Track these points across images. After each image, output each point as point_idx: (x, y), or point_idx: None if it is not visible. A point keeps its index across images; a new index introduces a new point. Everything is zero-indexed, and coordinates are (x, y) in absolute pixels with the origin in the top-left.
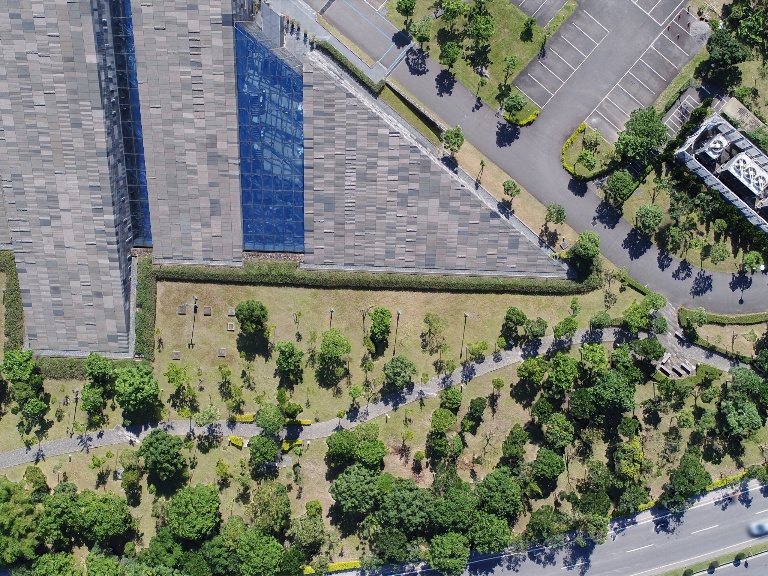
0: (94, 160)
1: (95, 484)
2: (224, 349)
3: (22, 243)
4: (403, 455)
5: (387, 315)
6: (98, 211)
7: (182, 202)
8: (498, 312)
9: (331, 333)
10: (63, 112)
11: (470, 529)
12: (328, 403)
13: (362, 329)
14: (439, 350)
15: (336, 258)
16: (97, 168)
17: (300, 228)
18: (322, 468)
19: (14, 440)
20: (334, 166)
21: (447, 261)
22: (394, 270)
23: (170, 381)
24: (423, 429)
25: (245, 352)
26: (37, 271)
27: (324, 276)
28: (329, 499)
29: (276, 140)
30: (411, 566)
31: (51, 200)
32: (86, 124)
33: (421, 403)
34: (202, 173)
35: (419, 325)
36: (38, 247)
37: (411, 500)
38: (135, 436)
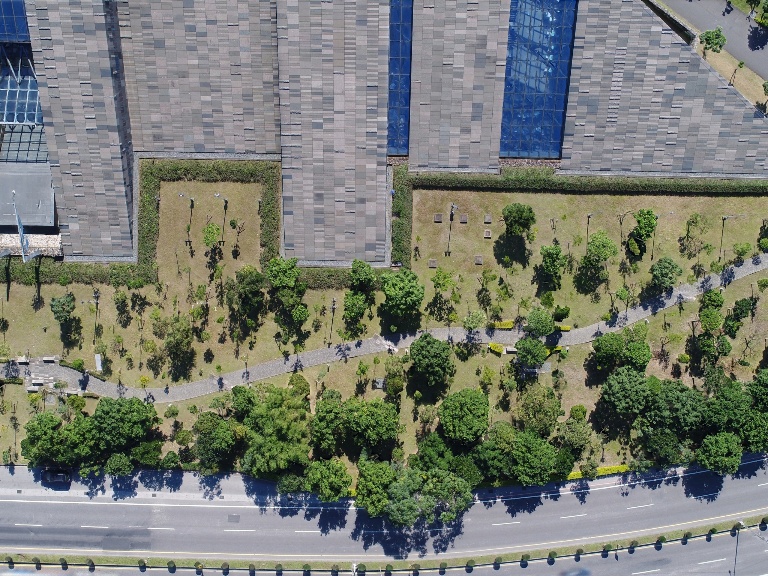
0: (375, 59)
1: (354, 394)
2: (481, 256)
3: (291, 148)
4: (662, 360)
5: (652, 217)
6: (372, 113)
7: (444, 107)
8: (756, 215)
9: (599, 235)
10: (350, 9)
11: (741, 429)
12: (586, 309)
13: (619, 234)
14: (697, 254)
15: (593, 163)
16: (377, 67)
17: (557, 133)
18: (581, 374)
19: (271, 351)
20: (602, 66)
21: (705, 164)
22: (650, 175)
23: (436, 286)
24: (682, 333)
25: (502, 259)
26: (303, 177)
27: (583, 181)
28: (589, 405)
29: (523, 49)
30: (673, 470)
31: (326, 102)
32: (371, 21)
33: (680, 307)
34: (468, 76)
35: (677, 229)
36: (307, 152)
37: (686, 399)
38: (393, 345)
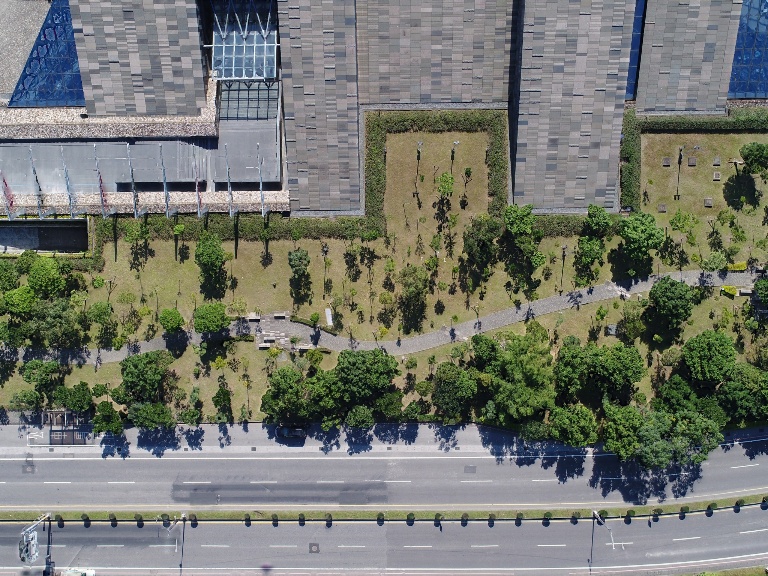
0: None
1: (586, 341)
2: (711, 199)
3: (530, 93)
4: None
5: None
6: (615, 54)
7: (676, 48)
8: None
9: None
10: None
11: None
12: None
13: None
14: None
15: None
16: (624, 6)
17: None
18: None
19: (502, 300)
20: None
21: None
22: None
23: (674, 228)
24: None
25: (733, 201)
26: (539, 123)
27: None
28: None
29: None
30: None
31: (570, 44)
32: None
33: None
34: (703, 15)
35: None
36: (545, 96)
37: None
38: (625, 290)
